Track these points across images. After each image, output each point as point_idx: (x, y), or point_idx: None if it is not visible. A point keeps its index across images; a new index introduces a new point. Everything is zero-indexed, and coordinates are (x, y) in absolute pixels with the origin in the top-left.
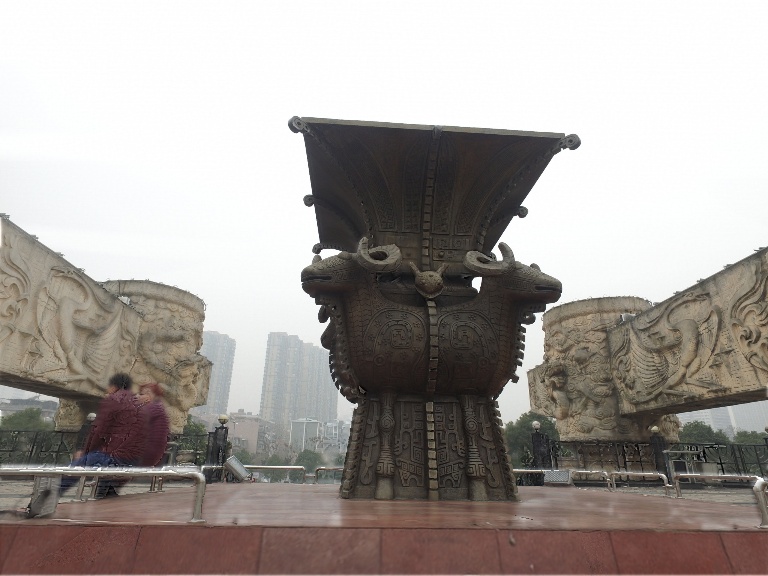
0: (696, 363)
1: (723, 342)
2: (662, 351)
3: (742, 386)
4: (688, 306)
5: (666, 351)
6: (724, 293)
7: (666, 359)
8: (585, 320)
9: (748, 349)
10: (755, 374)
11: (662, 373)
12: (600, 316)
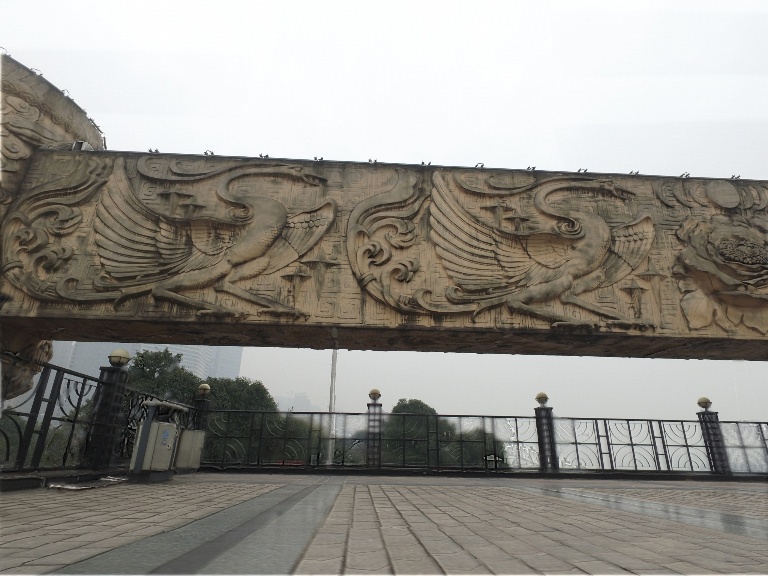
0: (260, 264)
1: (326, 249)
2: (193, 226)
3: (332, 316)
4: (279, 182)
5: (202, 229)
6: (353, 190)
7: (191, 241)
8: (1, 99)
9: (369, 270)
10: (361, 305)
11: (168, 261)
12: (38, 116)
